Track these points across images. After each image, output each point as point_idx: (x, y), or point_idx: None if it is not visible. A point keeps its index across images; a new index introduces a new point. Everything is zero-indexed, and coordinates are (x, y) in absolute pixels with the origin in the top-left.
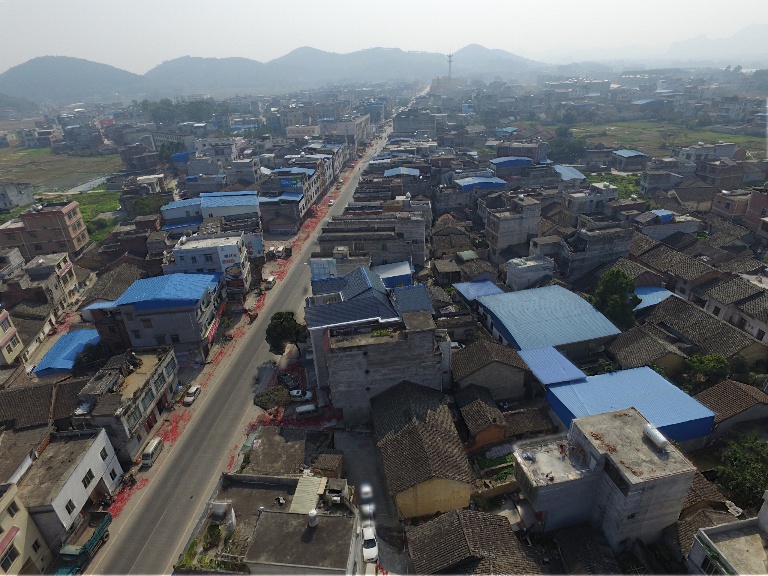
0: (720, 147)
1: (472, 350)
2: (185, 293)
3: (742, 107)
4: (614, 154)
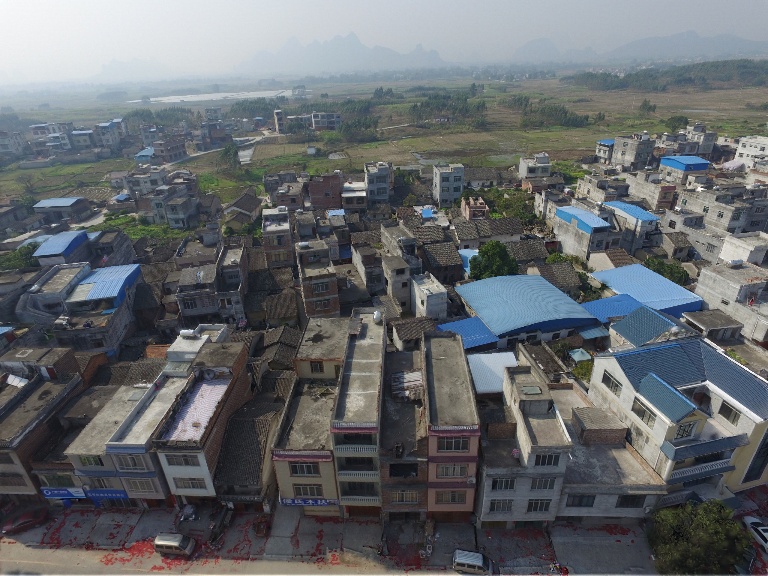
0: (147, 170)
1: None
2: None
3: (15, 141)
4: (40, 208)
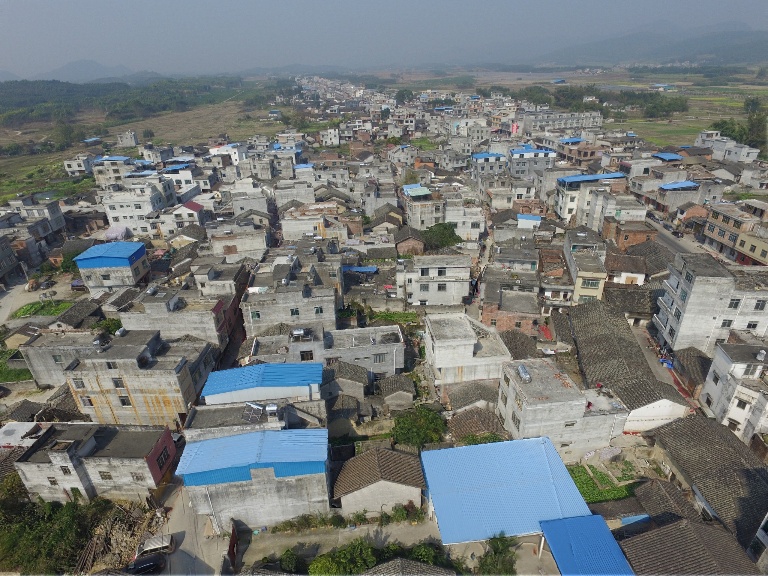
0: None
1: (735, 568)
2: None
3: None
4: None
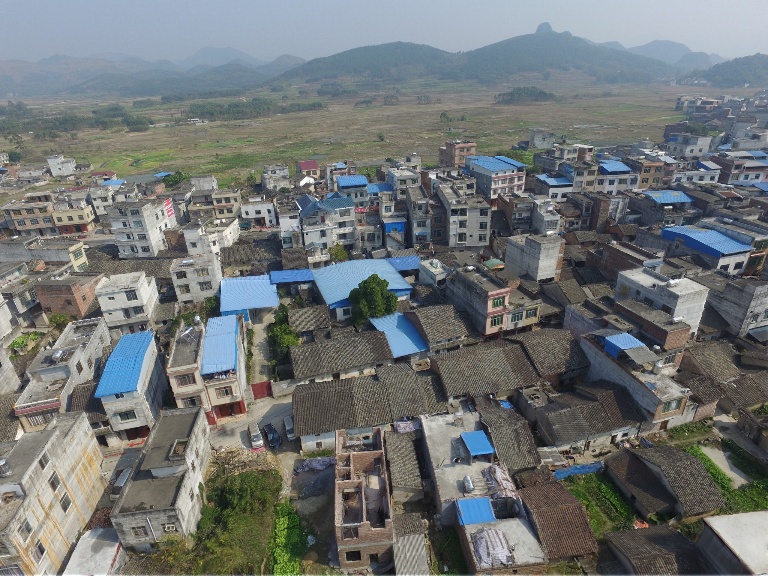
0: None
1: None
2: (344, 182)
3: None
4: None
